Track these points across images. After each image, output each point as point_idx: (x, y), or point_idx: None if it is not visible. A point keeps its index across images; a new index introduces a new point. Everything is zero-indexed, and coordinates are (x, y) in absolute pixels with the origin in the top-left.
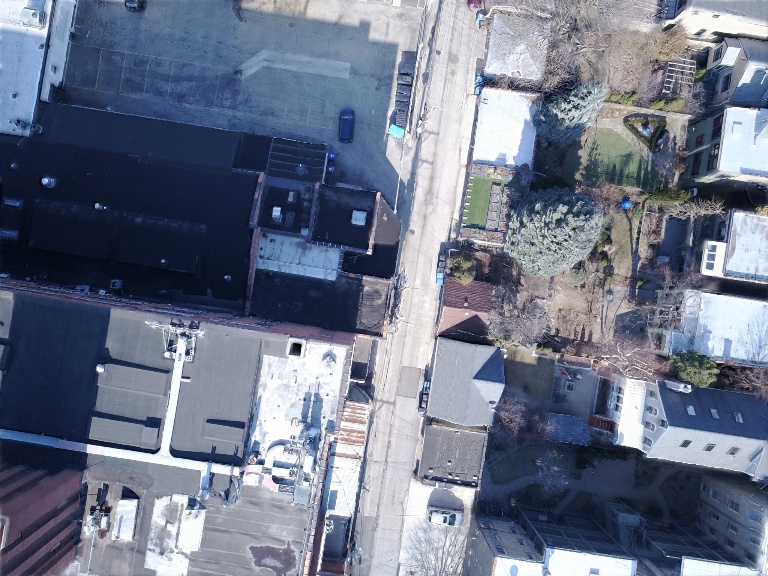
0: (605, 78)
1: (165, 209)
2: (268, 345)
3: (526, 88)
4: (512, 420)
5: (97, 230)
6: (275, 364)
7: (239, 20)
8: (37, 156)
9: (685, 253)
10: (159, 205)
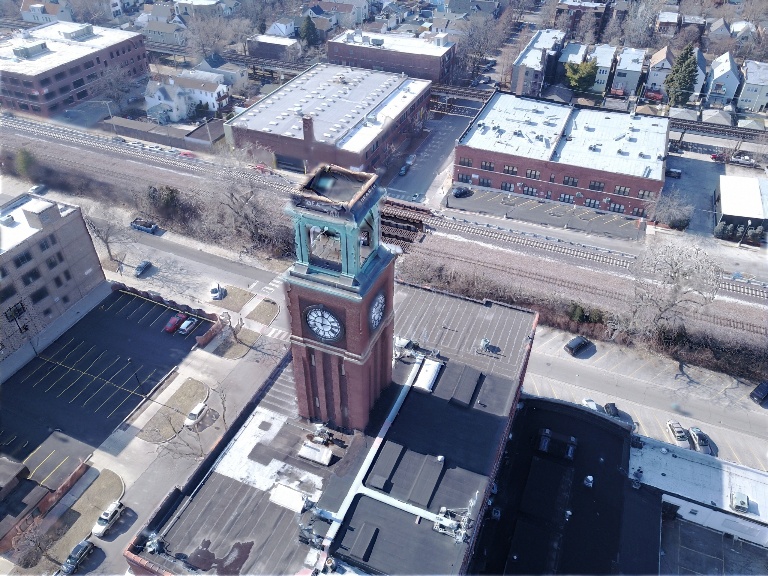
0: None
1: (566, 573)
2: None
3: None
4: None
5: (547, 509)
6: None
7: None
8: (612, 479)
9: None
10: (570, 568)
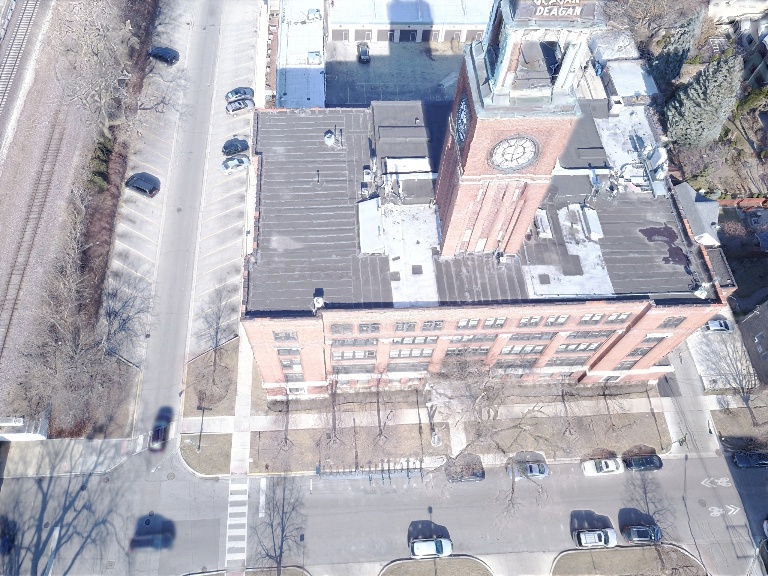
0: (695, 14)
1: None
2: (594, 109)
3: (632, 59)
4: (736, 229)
5: None
6: (601, 123)
7: (432, 60)
8: None
9: None
10: None
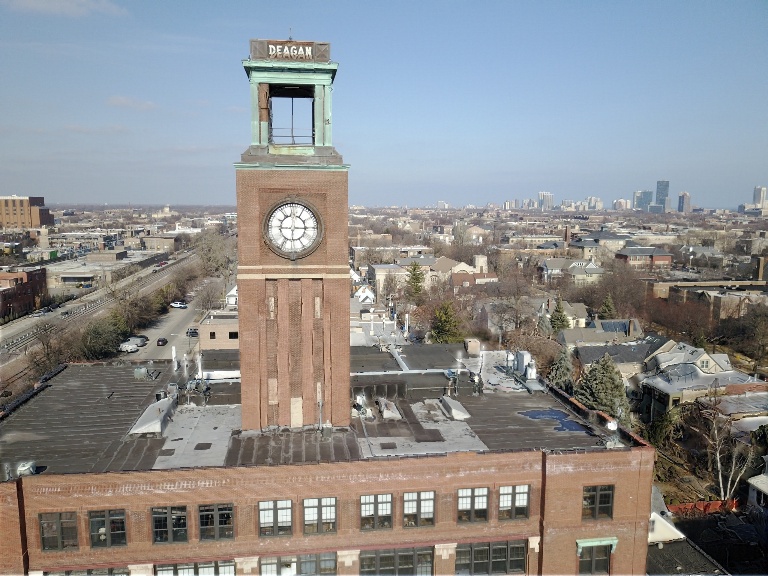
0: (562, 355)
1: None
2: (451, 352)
3: None
4: (692, 512)
5: None
6: (461, 361)
7: None
8: None
9: (704, 448)
10: None
